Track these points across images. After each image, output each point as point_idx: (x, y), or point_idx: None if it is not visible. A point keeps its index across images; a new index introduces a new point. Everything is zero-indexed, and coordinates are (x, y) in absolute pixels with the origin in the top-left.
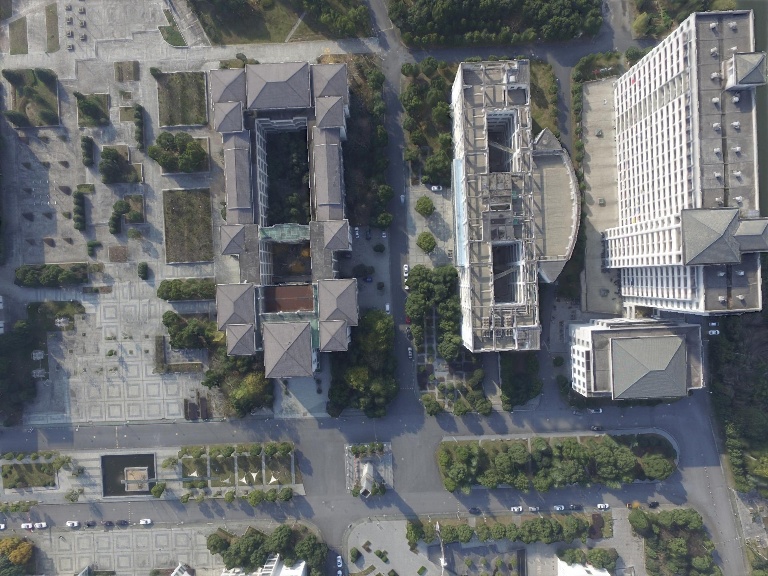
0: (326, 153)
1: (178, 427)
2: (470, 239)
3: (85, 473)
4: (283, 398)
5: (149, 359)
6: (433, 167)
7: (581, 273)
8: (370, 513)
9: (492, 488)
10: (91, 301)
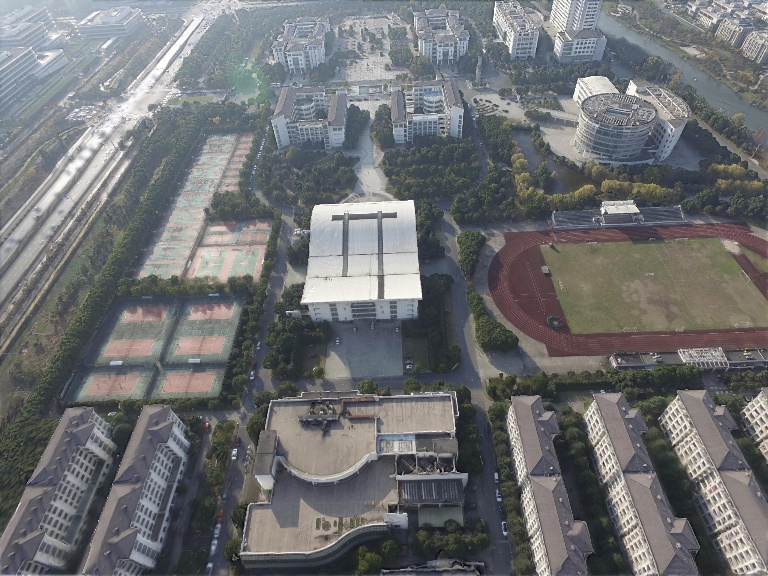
0: (454, 17)
1: (393, 80)
2: (507, 20)
3: (351, 90)
4: (438, 73)
5: (382, 68)
6: (490, 29)
7: (553, 46)
8: (480, 93)
9: (534, 80)
10: (360, 60)
